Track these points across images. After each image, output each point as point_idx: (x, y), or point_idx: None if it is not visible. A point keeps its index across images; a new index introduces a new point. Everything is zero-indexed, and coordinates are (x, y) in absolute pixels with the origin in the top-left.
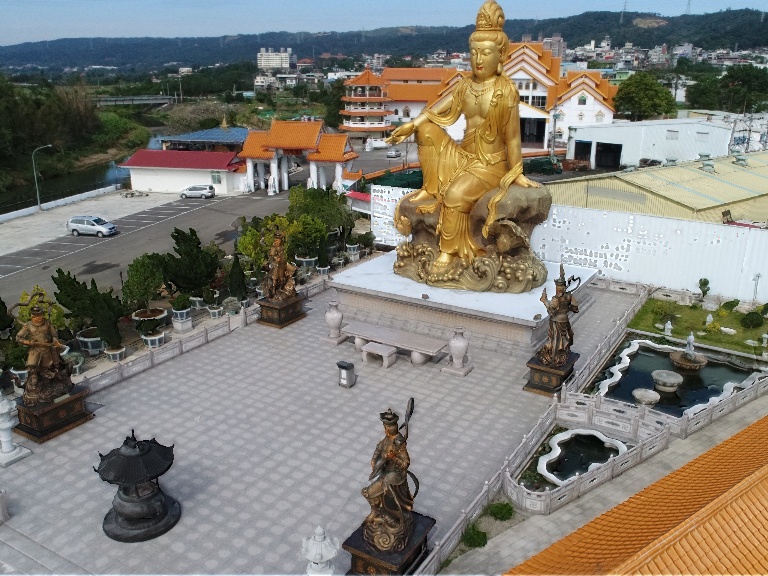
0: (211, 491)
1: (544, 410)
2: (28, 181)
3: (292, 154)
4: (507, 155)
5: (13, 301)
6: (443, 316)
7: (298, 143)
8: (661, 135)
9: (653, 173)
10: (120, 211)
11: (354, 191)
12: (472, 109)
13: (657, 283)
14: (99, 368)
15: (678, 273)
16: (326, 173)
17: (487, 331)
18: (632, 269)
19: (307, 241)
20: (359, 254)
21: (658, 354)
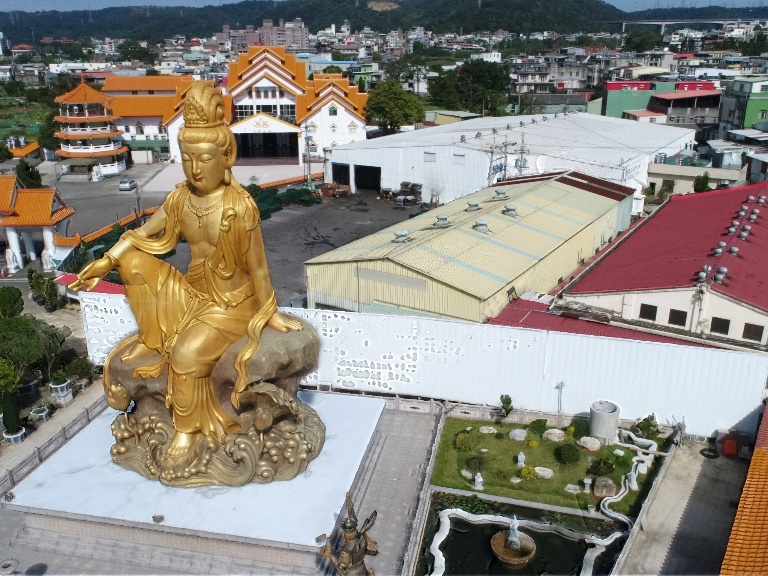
0: None
1: None
2: None
3: None
4: (253, 288)
5: None
6: (188, 538)
7: None
8: (419, 157)
9: (428, 245)
10: None
11: (70, 265)
12: (195, 233)
13: (452, 395)
14: None
15: (474, 383)
16: (32, 237)
17: (254, 555)
18: (422, 380)
19: None
20: (71, 392)
21: (473, 528)
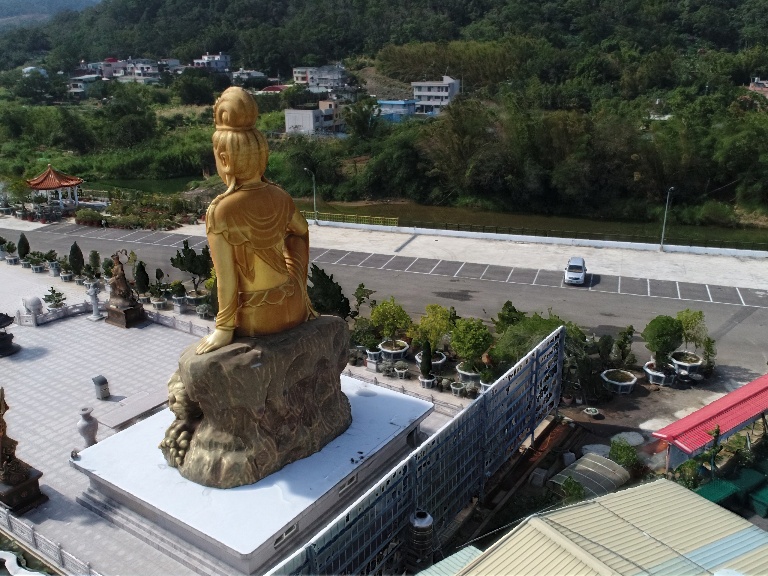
0: (7, 363)
1: None
2: (656, 218)
3: None
4: None
5: (365, 285)
6: None
7: None
8: None
9: None
10: (691, 275)
11: None
12: None
13: None
14: (208, 322)
15: None
16: None
17: None
18: None
19: None
20: None
21: None
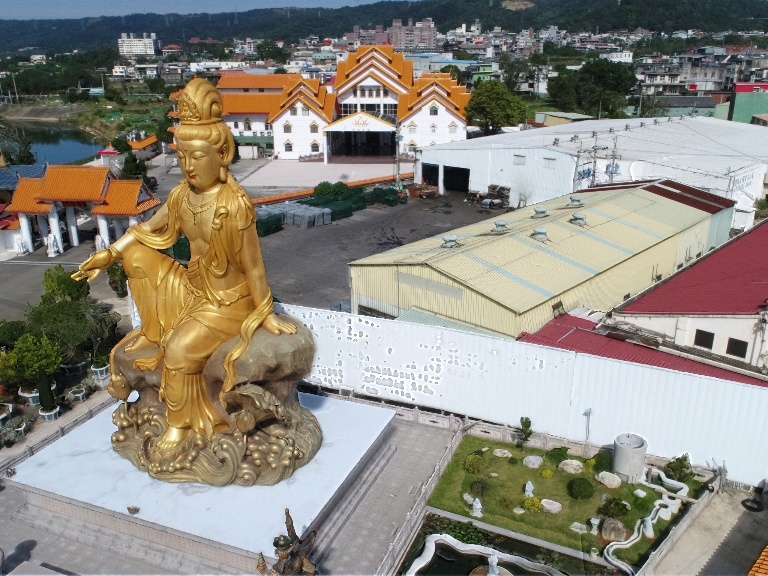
0: None
1: None
2: None
3: (74, 206)
4: (250, 288)
5: None
6: (162, 533)
7: (79, 194)
8: (508, 160)
9: (474, 252)
10: None
11: None
12: (191, 230)
13: (475, 412)
14: None
15: (498, 401)
16: (122, 225)
17: (221, 558)
18: (445, 394)
19: (28, 373)
20: None
21: (461, 557)
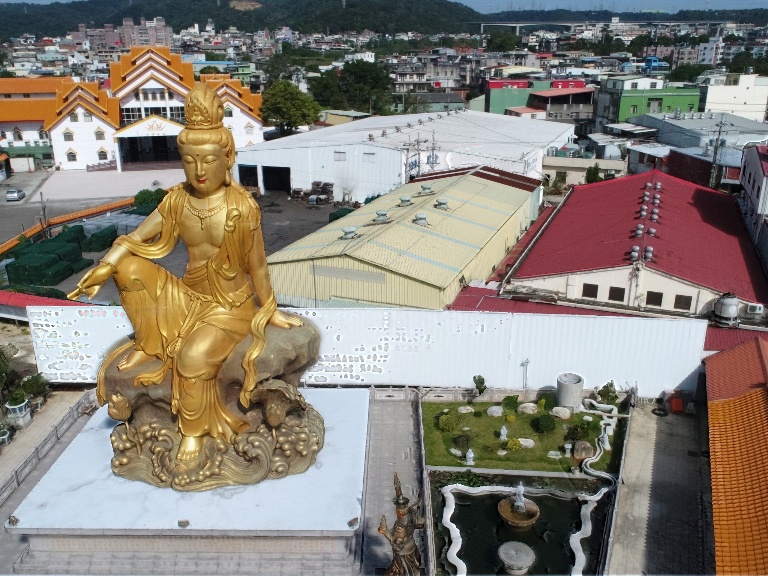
0: None
1: None
2: None
3: None
4: (253, 288)
5: None
6: (213, 540)
7: None
8: (329, 157)
9: (378, 240)
10: None
11: None
12: (197, 235)
13: (423, 381)
14: None
15: (444, 368)
16: None
17: (282, 548)
18: (393, 369)
19: None
20: (29, 412)
21: (474, 500)
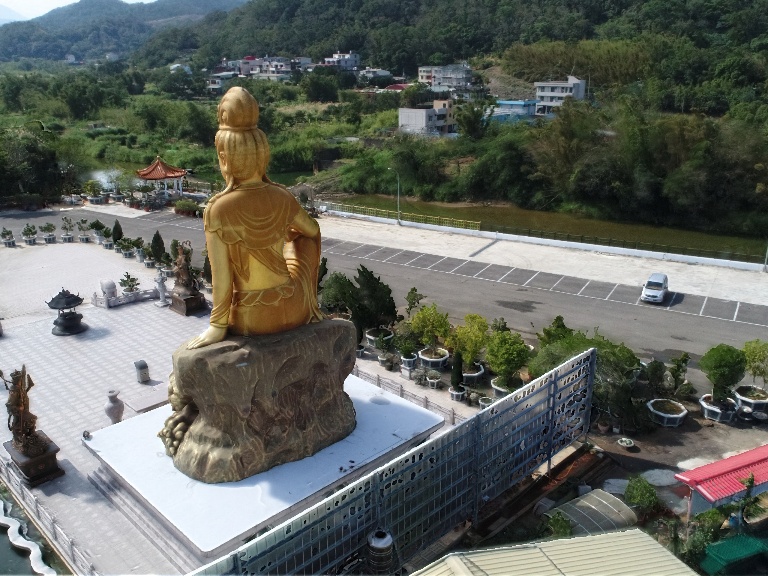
0: (72, 341)
1: (7, 454)
2: (760, 235)
3: None
4: None
5: None
6: None
7: None
8: None
9: None
10: None
11: None
12: None
13: None
14: None
15: None
16: None
17: None
18: None
19: None
20: None
21: None
